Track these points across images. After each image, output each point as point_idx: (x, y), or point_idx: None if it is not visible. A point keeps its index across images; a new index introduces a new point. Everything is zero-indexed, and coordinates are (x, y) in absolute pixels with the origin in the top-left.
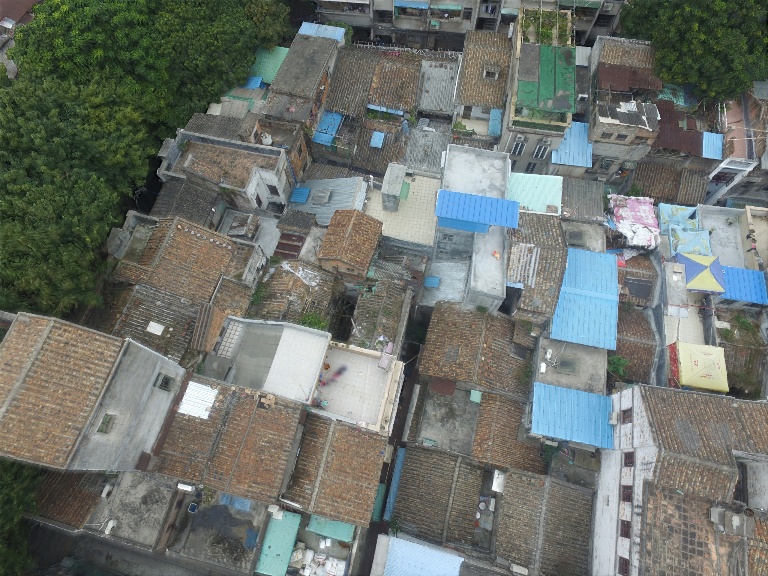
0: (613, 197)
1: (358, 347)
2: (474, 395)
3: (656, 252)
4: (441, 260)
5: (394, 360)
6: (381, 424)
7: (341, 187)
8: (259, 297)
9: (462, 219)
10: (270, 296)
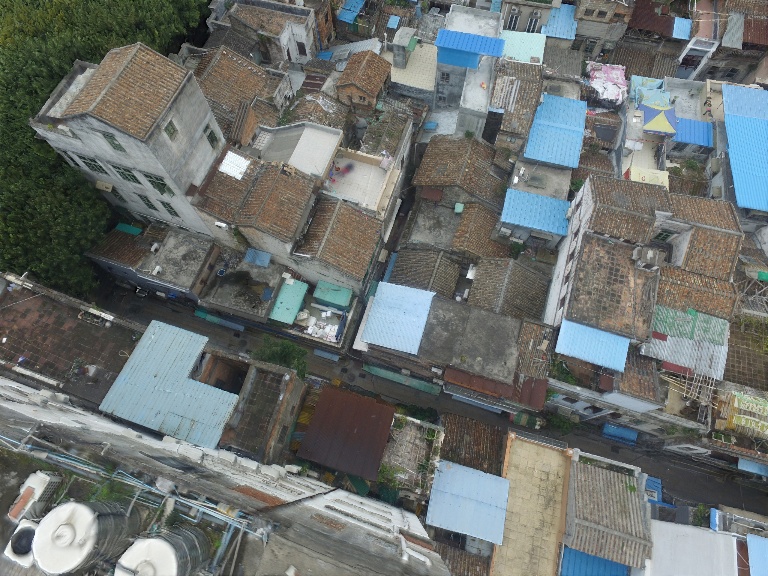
0: (591, 63)
1: (364, 153)
2: (458, 207)
3: (623, 106)
4: (440, 110)
5: (393, 163)
6: (378, 210)
7: (359, 47)
8: (285, 119)
9: (456, 48)
10: (294, 118)
